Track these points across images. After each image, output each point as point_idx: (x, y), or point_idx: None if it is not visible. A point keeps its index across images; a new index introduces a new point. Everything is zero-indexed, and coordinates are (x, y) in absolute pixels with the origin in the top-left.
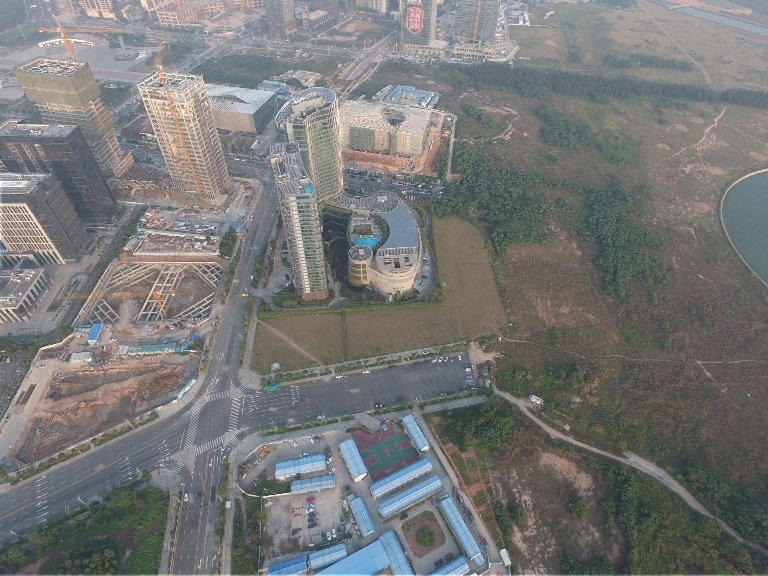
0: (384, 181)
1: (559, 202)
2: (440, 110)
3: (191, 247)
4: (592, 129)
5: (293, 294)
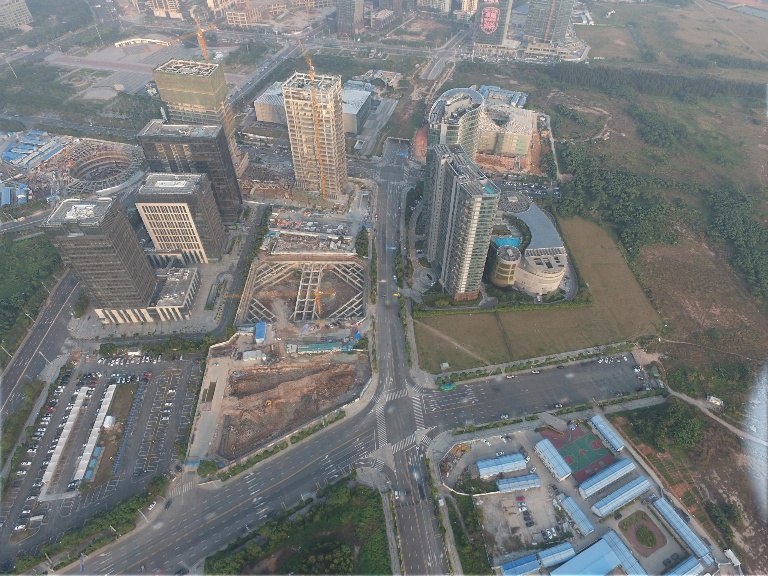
0: (496, 181)
1: (678, 203)
2: None
3: (326, 247)
4: (688, 129)
5: (445, 294)
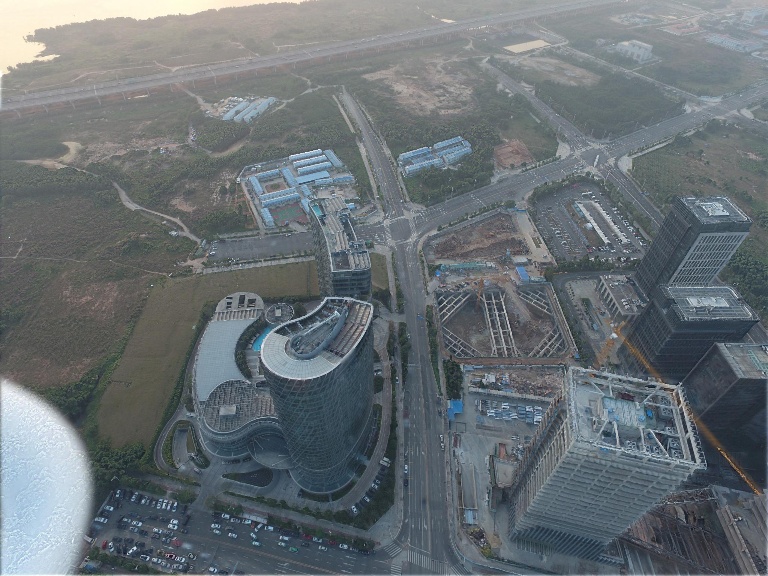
0: (201, 572)
1: None
2: None
3: None
4: None
5: None
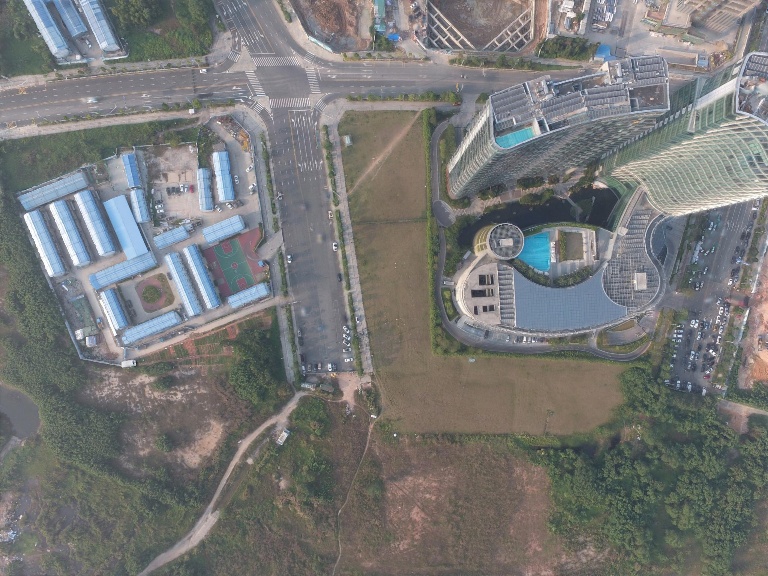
0: (730, 291)
1: None
2: None
3: None
4: None
5: (454, 151)
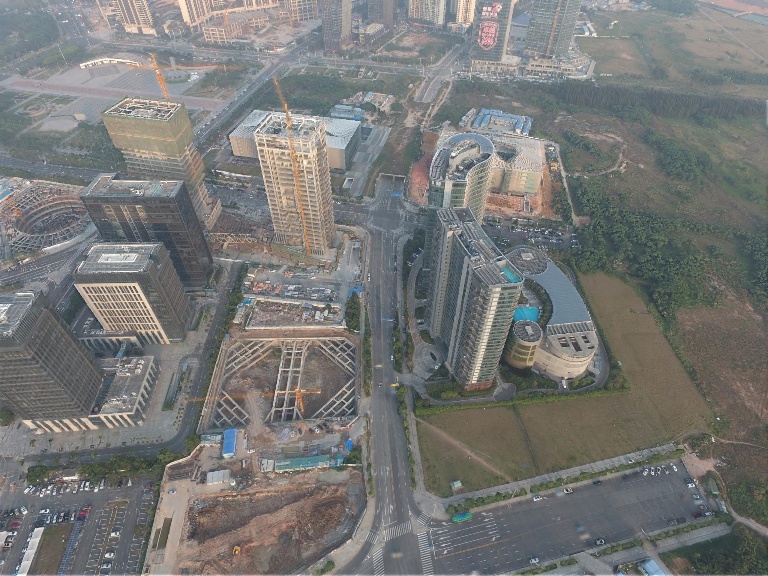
0: (504, 227)
1: (713, 251)
2: (537, 137)
3: (310, 318)
4: (712, 158)
5: (452, 383)
